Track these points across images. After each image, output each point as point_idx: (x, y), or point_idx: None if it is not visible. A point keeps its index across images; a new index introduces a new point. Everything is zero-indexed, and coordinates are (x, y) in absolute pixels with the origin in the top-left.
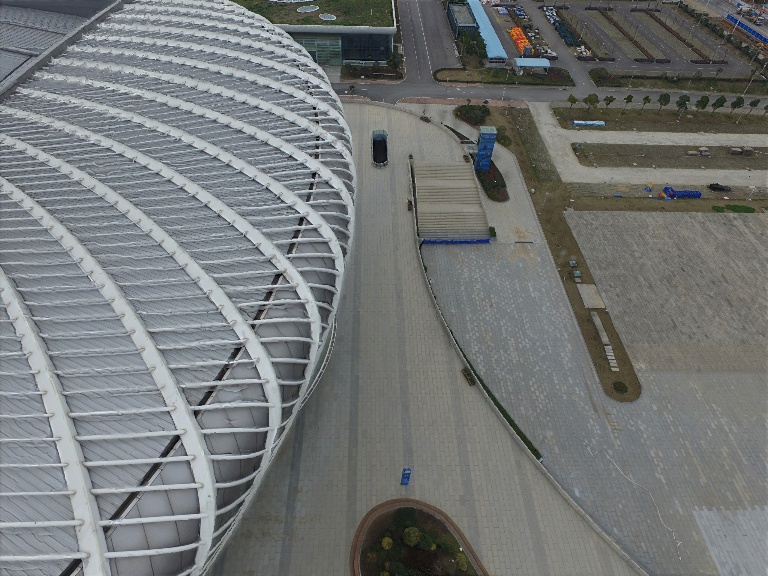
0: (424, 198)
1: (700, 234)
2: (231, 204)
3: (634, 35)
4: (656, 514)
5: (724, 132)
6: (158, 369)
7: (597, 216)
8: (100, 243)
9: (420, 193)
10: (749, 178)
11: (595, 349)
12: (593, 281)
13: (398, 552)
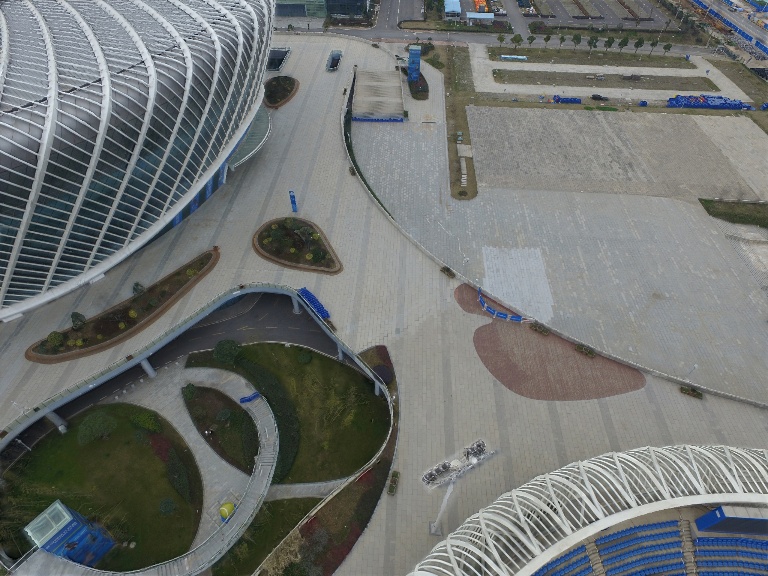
0: (360, 93)
1: (565, 121)
2: (185, 3)
3: None
4: (458, 247)
5: (625, 66)
6: (138, 42)
7: (490, 109)
8: (119, 7)
9: (358, 89)
10: (629, 94)
11: (455, 176)
12: (470, 143)
13: (280, 231)
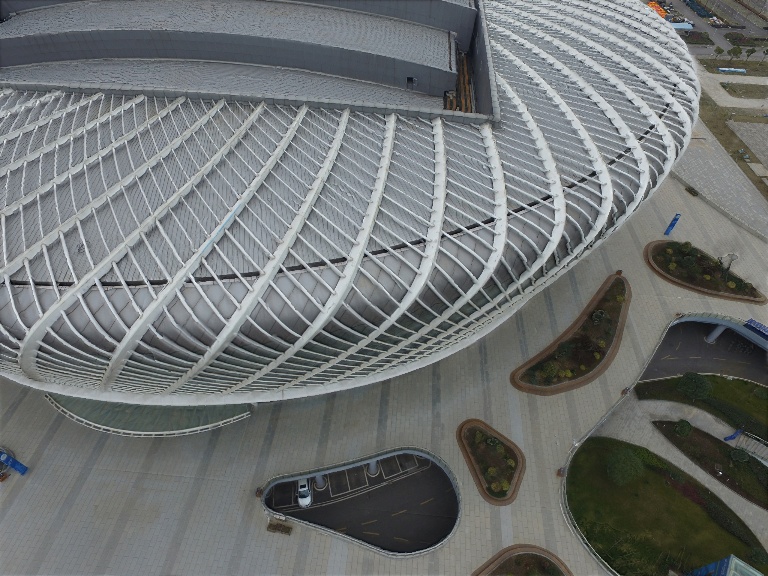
0: None
1: None
2: None
3: (760, 10)
4: None
5: None
6: (656, 63)
7: (754, 126)
8: None
9: None
10: None
11: None
12: (760, 161)
13: (677, 256)
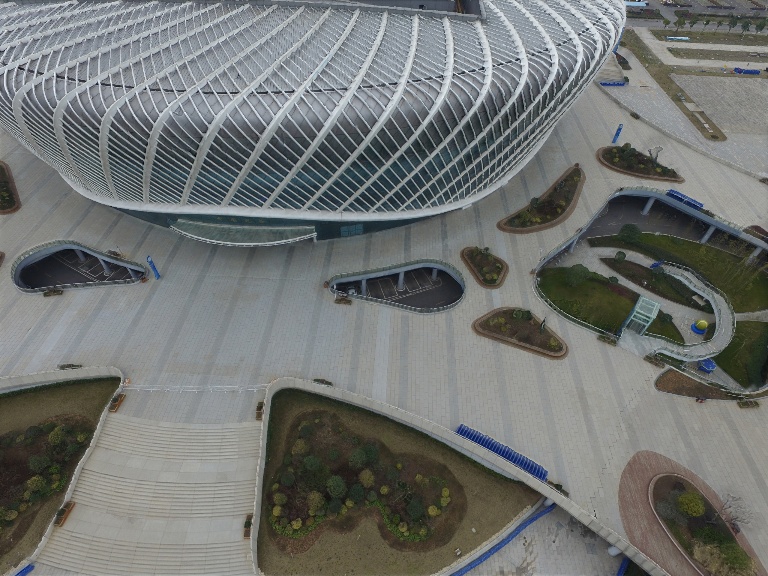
0: None
1: (760, 87)
2: None
3: None
4: None
5: None
6: None
7: (691, 77)
8: None
9: None
10: None
11: (698, 125)
12: (693, 101)
13: None
